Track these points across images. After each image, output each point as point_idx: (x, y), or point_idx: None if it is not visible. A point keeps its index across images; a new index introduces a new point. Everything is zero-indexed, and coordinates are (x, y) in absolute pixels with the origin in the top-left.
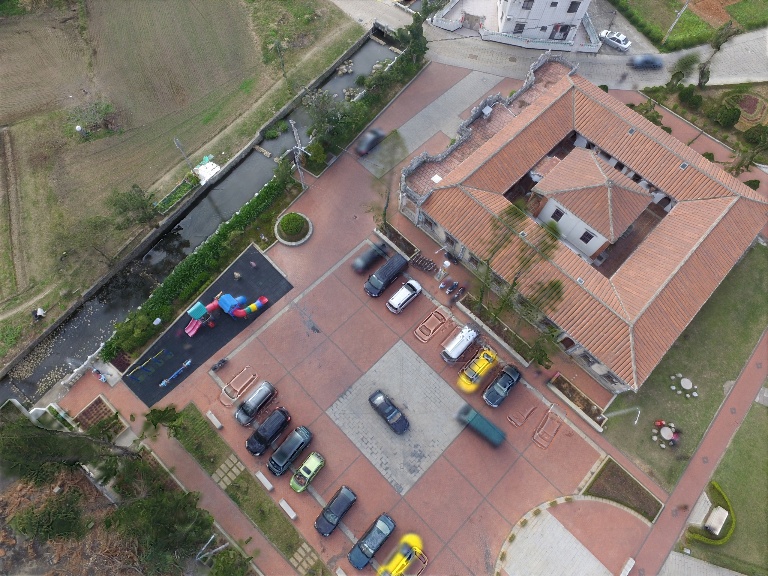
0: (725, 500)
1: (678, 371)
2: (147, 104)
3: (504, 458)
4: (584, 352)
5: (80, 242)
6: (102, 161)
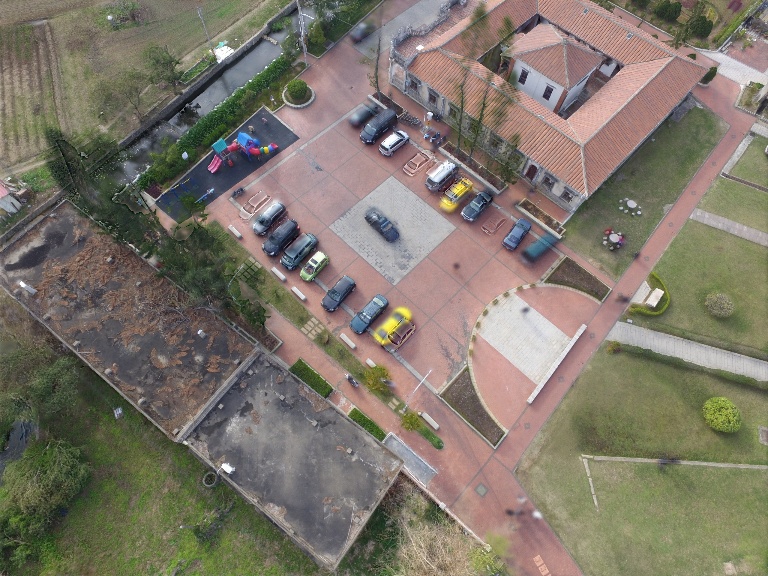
0: (662, 285)
1: (626, 197)
2: (168, 3)
3: (479, 259)
4: (545, 174)
5: (120, 88)
6: (131, 45)
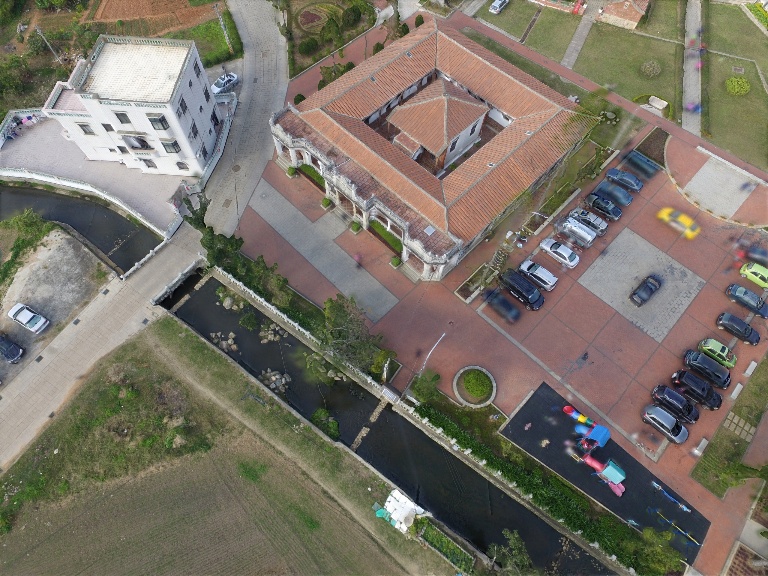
0: (644, 96)
1: None
2: None
3: (655, 212)
4: None
5: None
6: None
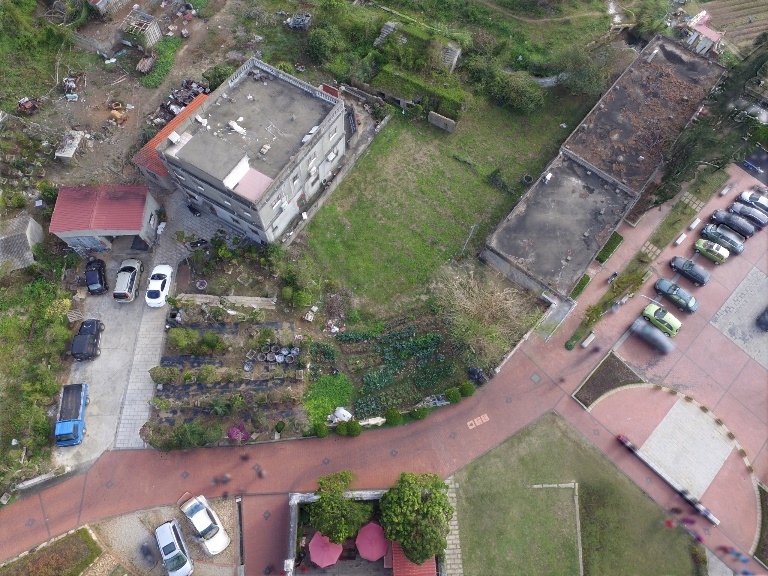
0: None
1: None
2: None
3: (765, 413)
4: None
5: None
6: None
